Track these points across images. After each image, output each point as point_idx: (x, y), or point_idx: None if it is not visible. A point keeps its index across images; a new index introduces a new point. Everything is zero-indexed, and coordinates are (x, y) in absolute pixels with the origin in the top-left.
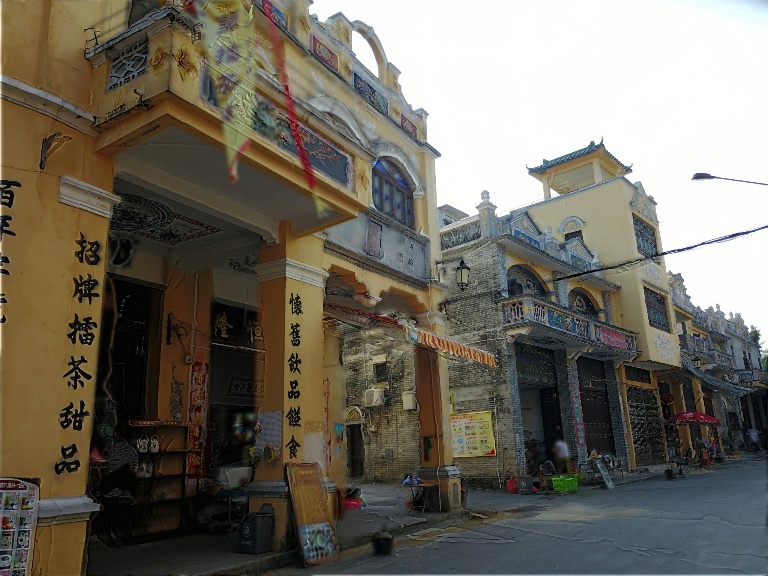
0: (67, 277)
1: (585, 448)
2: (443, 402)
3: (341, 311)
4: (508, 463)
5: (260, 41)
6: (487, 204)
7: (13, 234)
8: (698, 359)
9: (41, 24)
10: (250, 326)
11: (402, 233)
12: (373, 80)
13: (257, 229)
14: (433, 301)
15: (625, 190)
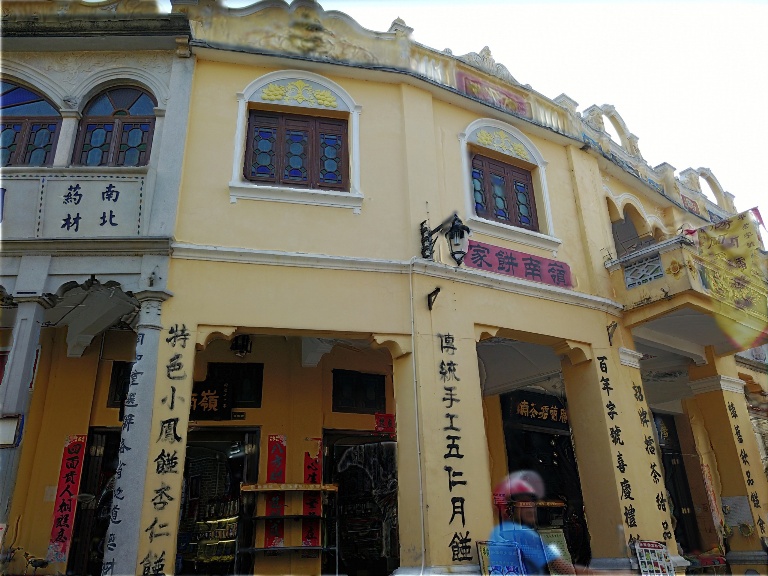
0: (636, 411)
1: None
2: None
3: (765, 412)
4: None
5: (658, 213)
6: None
7: (612, 389)
8: None
9: (585, 255)
10: None
11: None
12: (720, 211)
13: (692, 355)
14: None
15: None
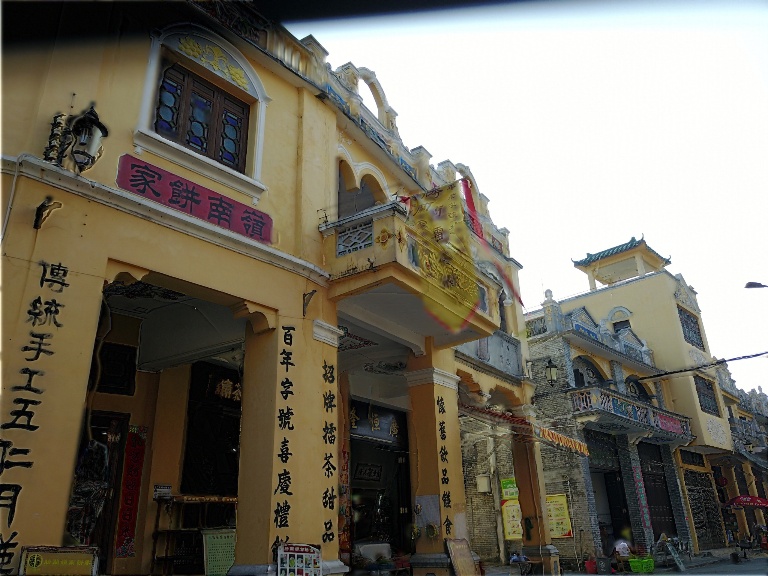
0: (320, 394)
1: (651, 531)
2: (540, 486)
3: (473, 410)
4: (585, 544)
5: None
6: (551, 302)
7: (293, 365)
8: (750, 443)
9: (296, 211)
10: (372, 418)
11: (501, 338)
12: (472, 210)
13: (411, 344)
14: (526, 395)
15: (669, 283)
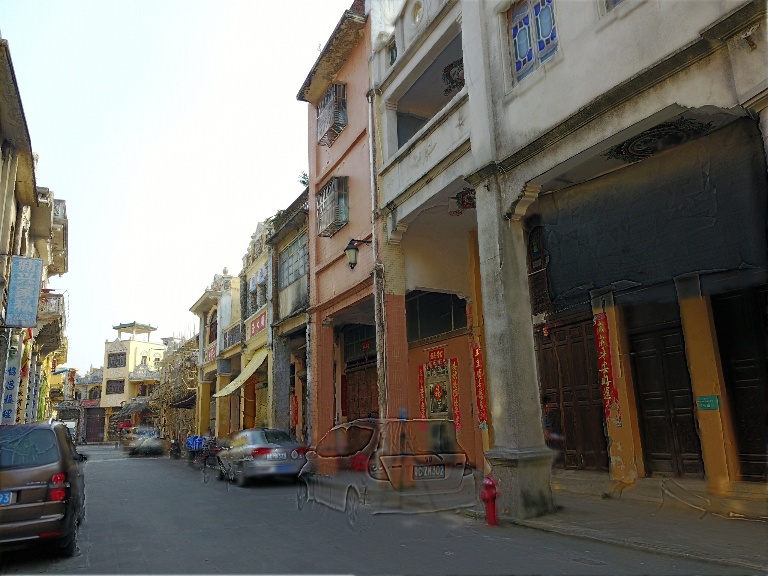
0: None
1: (82, 435)
2: None
3: None
4: None
5: None
6: None
7: None
8: None
9: None
10: None
11: None
12: None
13: None
14: None
15: None
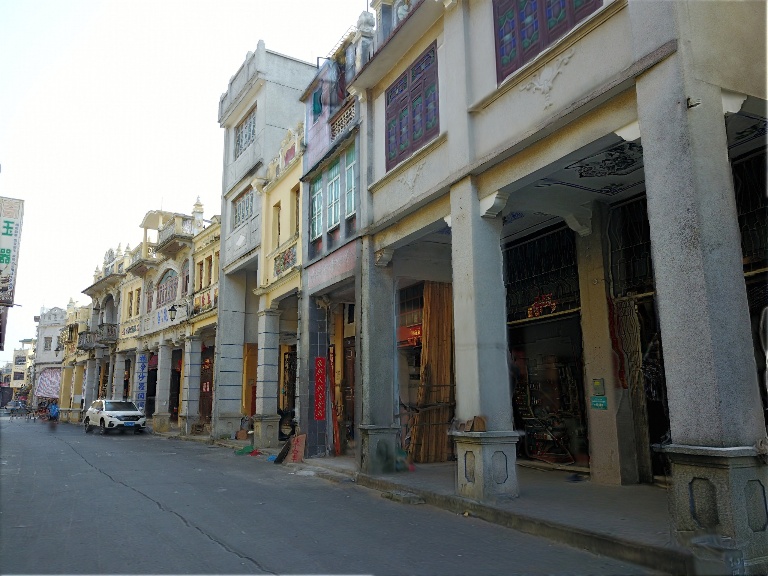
0: None
1: None
2: None
3: None
4: None
5: None
6: None
7: None
8: None
9: None
10: None
11: None
12: None
13: None
14: None
15: None
